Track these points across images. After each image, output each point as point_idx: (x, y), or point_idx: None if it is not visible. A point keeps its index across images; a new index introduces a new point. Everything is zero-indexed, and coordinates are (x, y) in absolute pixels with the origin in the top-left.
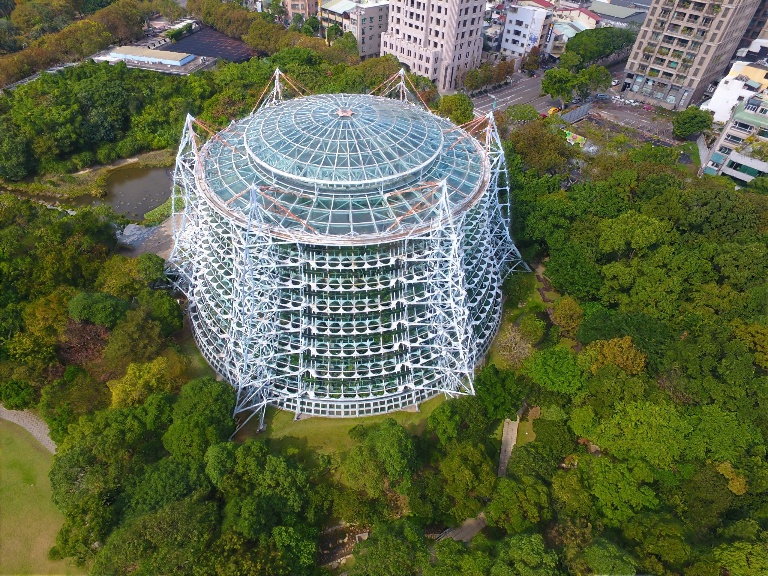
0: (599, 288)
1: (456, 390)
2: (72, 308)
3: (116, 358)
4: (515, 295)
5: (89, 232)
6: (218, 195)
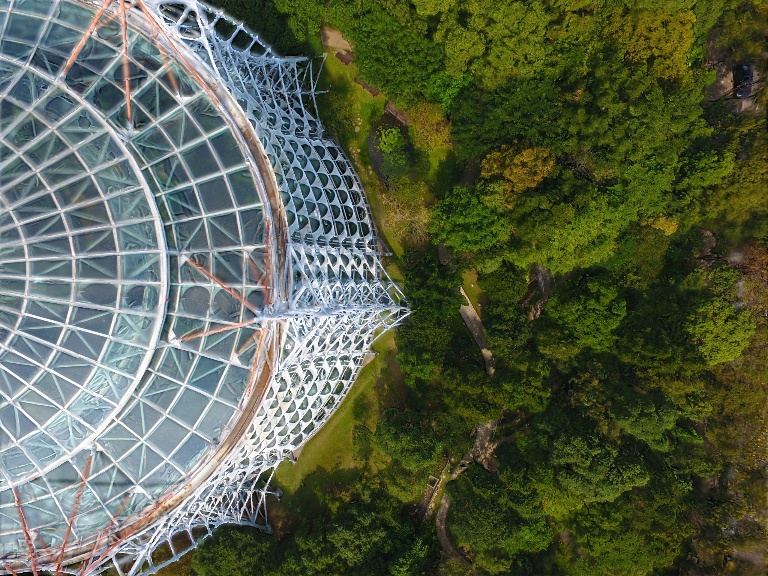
0: (443, 65)
1: None
2: None
3: None
4: (348, 132)
5: None
6: None
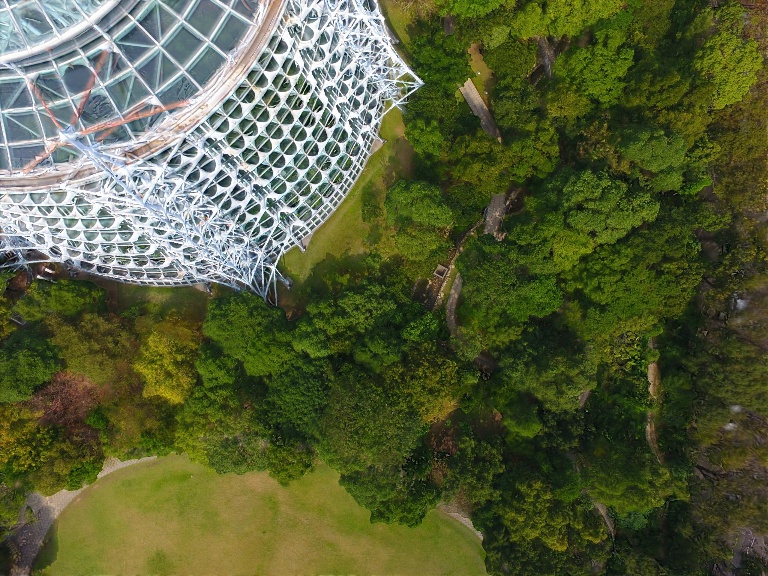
0: None
1: (395, 90)
2: (4, 398)
3: (111, 375)
4: None
5: None
6: None
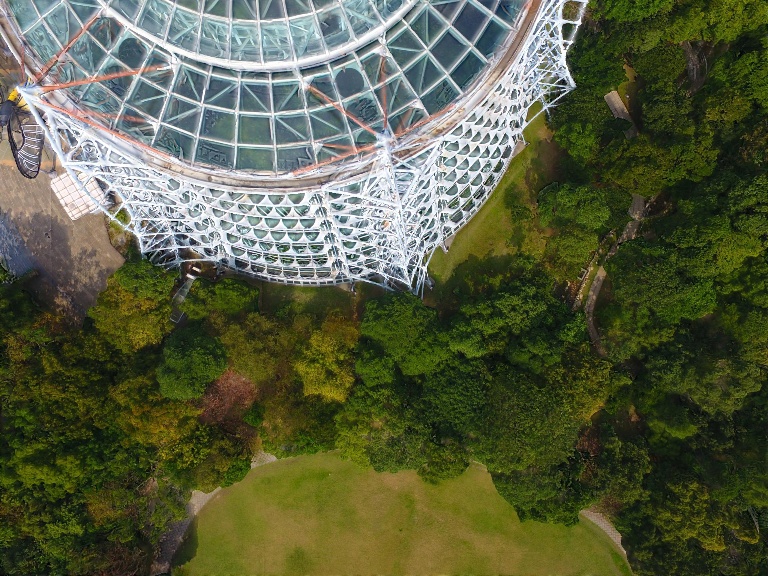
0: None
1: None
2: (178, 396)
3: (270, 374)
4: None
5: (8, 324)
6: (243, 169)
